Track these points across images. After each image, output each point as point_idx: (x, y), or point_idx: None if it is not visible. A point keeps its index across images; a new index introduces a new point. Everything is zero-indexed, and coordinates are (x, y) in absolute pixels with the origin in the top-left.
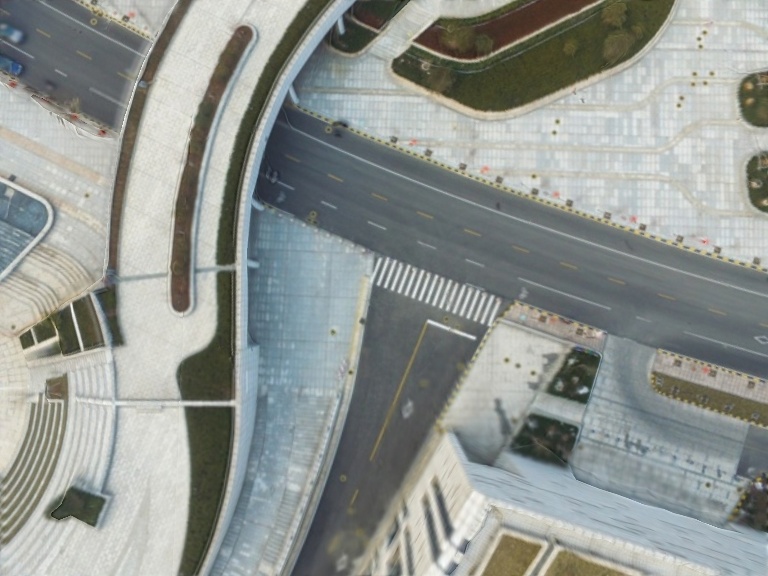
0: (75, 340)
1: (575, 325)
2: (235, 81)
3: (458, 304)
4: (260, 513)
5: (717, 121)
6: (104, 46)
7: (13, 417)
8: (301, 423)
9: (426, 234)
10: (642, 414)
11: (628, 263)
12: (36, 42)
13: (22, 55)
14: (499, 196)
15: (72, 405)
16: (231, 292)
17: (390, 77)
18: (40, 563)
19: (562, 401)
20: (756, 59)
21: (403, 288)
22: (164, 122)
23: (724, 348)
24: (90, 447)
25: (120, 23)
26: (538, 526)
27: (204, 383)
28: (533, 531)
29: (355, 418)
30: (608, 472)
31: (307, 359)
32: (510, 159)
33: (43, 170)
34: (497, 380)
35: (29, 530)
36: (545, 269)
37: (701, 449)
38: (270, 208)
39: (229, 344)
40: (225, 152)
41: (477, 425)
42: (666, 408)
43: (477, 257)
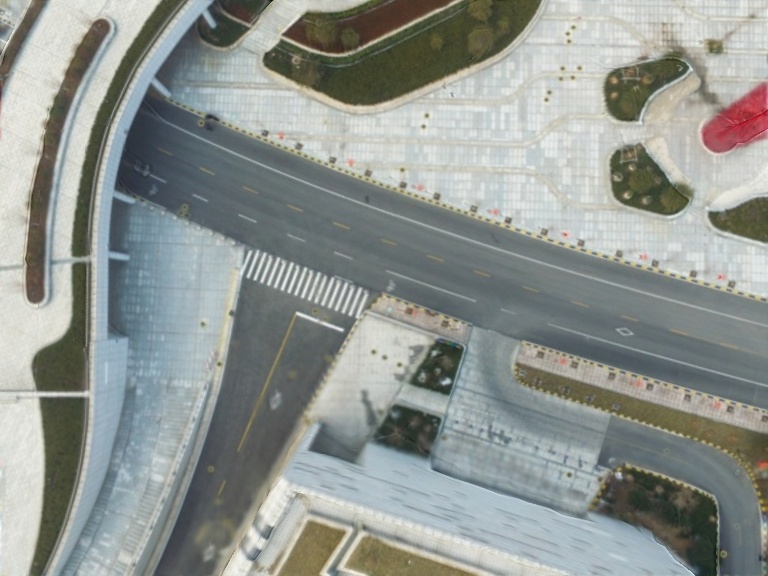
0: None
1: (441, 317)
2: (92, 74)
3: (326, 296)
4: (122, 503)
5: (583, 115)
6: None
7: None
8: (168, 414)
9: (296, 227)
10: (505, 405)
11: (494, 256)
12: None
13: None
14: (368, 189)
15: None
16: (86, 284)
17: (262, 71)
18: None
19: (426, 392)
20: (623, 54)
21: (272, 280)
22: (21, 115)
23: (586, 340)
24: None
25: None
26: (345, 512)
27: (58, 374)
28: (341, 517)
29: (223, 409)
30: (471, 462)
31: (176, 351)
32: (379, 153)
33: None
34: (364, 372)
35: None
36: (412, 262)
37: (563, 439)
38: (142, 201)
39: (83, 335)
40: (81, 144)
41: (343, 416)
42: (529, 399)
43: (346, 250)
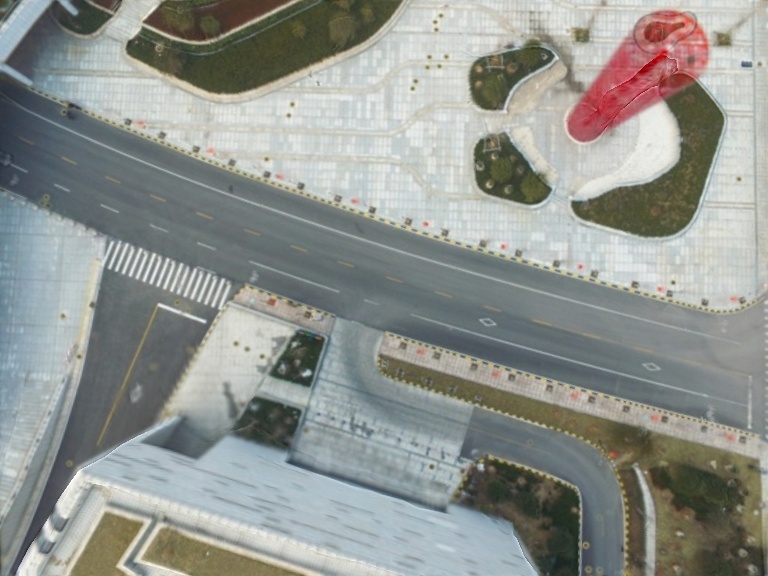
0: None
1: (303, 308)
2: None
3: (189, 288)
4: None
5: (449, 104)
6: None
7: None
8: (24, 408)
9: (158, 217)
10: (368, 397)
11: (358, 246)
12: None
13: None
14: (232, 179)
15: None
16: None
17: (125, 59)
18: None
19: (287, 384)
20: (490, 42)
21: (134, 272)
22: None
23: (449, 330)
24: None
25: None
26: (146, 504)
27: None
28: (141, 509)
29: (83, 403)
30: (332, 455)
31: (36, 343)
32: (244, 142)
33: None
34: (226, 364)
35: None
36: (276, 252)
37: (426, 431)
38: (2, 191)
39: None
40: None
41: (204, 409)
42: (392, 391)
43: (209, 240)
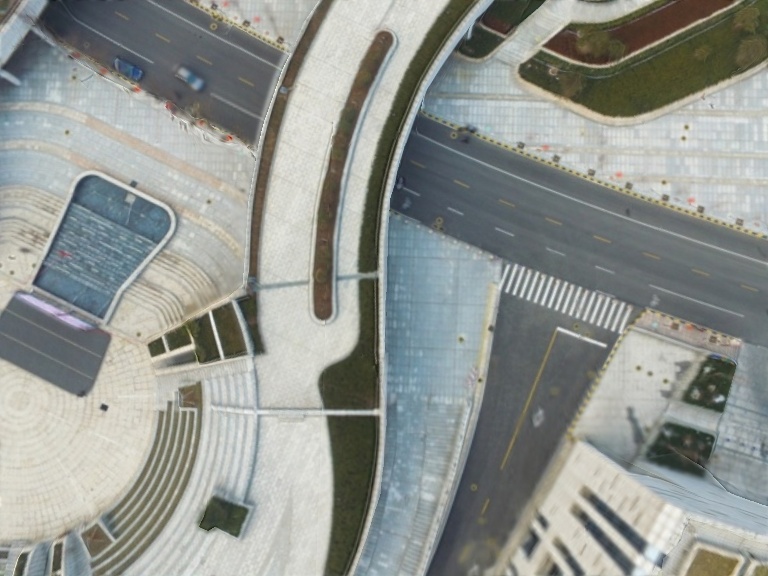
0: (214, 348)
1: (708, 333)
2: (376, 87)
3: (588, 311)
4: (396, 523)
5: None
6: (225, 51)
7: (139, 425)
8: (432, 432)
9: (555, 241)
10: None
11: (761, 270)
12: (156, 47)
13: (142, 60)
14: (629, 202)
15: (207, 414)
16: (374, 300)
17: (516, 82)
18: (180, 574)
19: (697, 409)
20: None
21: (532, 295)
22: (304, 128)
23: None
24: (229, 456)
25: (241, 28)
26: (731, 540)
27: (347, 392)
28: (726, 545)
29: (485, 426)
30: (744, 481)
31: (436, 367)
32: (639, 165)
33: (164, 176)
34: (629, 388)
35: (165, 540)
36: (676, 276)
37: None
38: (396, 214)
39: (372, 352)
40: (366, 158)
41: (610, 434)
42: None
43: (607, 264)
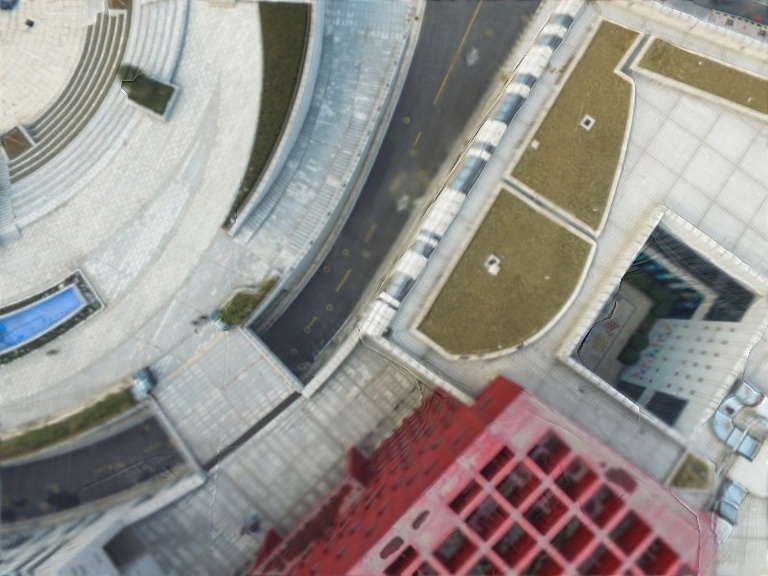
0: None
1: None
2: None
3: None
4: (327, 135)
5: None
6: None
7: (66, 43)
8: (367, 60)
9: None
10: None
11: None
12: None
13: None
14: None
15: (136, 11)
16: None
17: None
18: (101, 156)
19: None
20: None
21: None
22: None
23: None
24: (157, 44)
25: None
26: (635, 21)
27: None
28: (630, 26)
29: (420, 62)
30: None
31: (374, 3)
32: None
33: None
34: None
35: (88, 133)
36: None
37: None
38: None
39: None
40: None
41: None
42: None
43: None
